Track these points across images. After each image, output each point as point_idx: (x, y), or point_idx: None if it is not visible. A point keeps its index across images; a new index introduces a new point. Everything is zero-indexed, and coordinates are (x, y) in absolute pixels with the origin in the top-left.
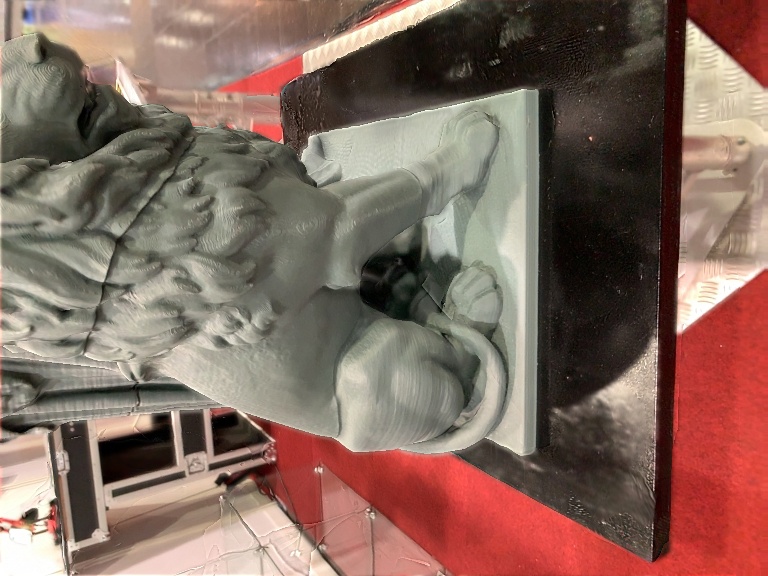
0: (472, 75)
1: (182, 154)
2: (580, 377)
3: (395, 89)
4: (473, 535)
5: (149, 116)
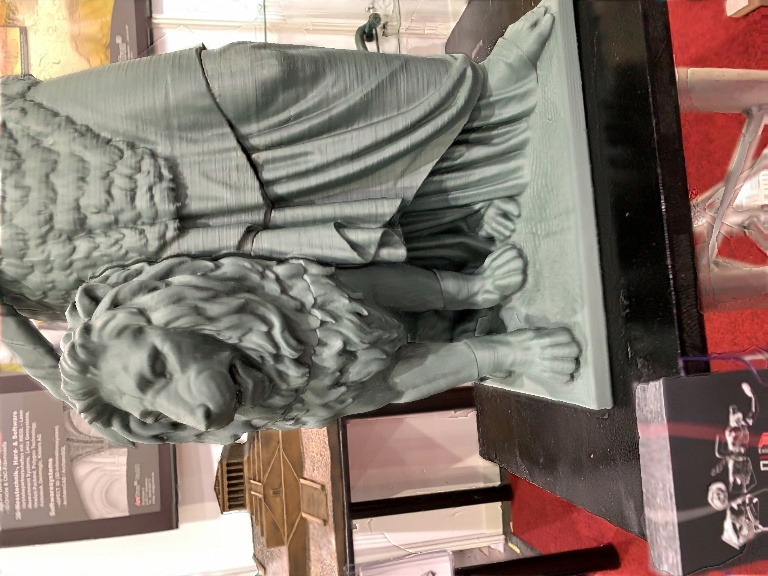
0: (621, 316)
1: (294, 399)
2: (511, 422)
3: (614, 166)
4: None
5: (282, 356)
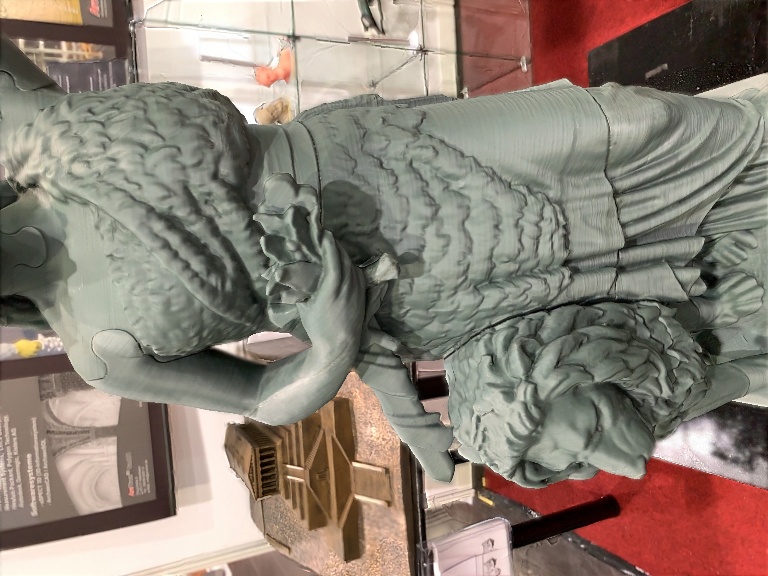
0: None
1: None
2: None
3: None
4: None
5: None
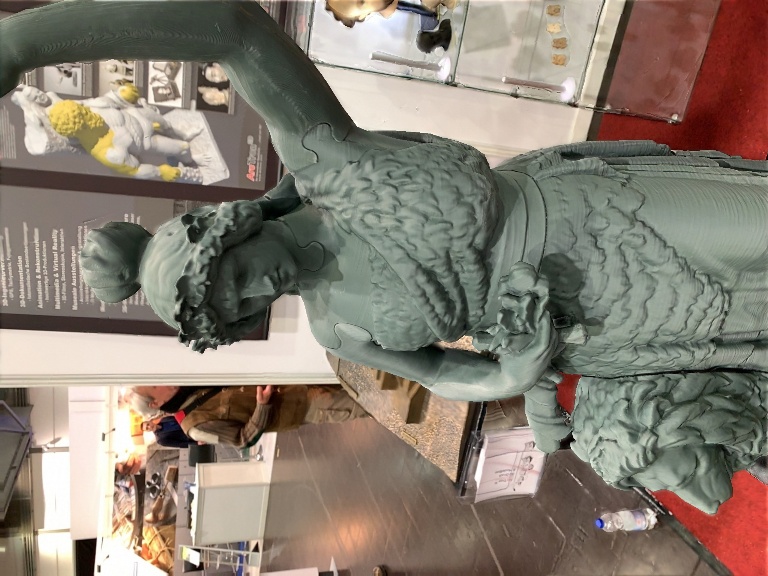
0: None
1: None
2: None
3: None
4: (761, 26)
5: None
